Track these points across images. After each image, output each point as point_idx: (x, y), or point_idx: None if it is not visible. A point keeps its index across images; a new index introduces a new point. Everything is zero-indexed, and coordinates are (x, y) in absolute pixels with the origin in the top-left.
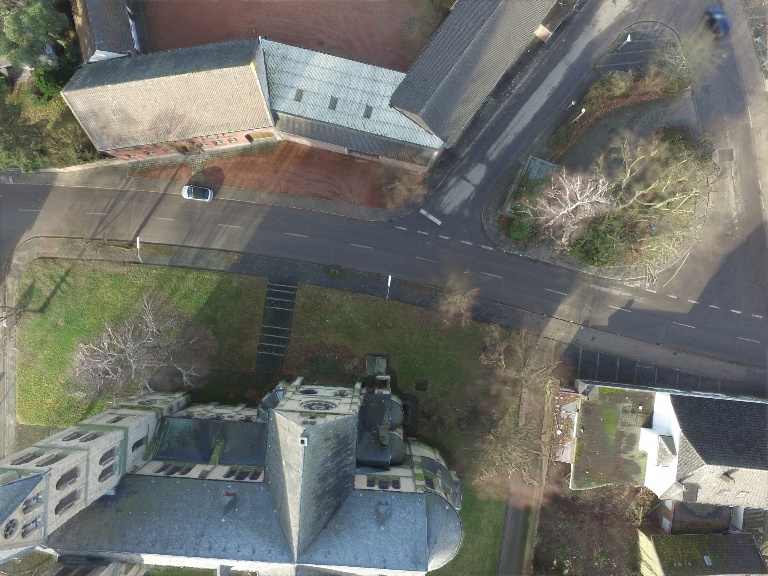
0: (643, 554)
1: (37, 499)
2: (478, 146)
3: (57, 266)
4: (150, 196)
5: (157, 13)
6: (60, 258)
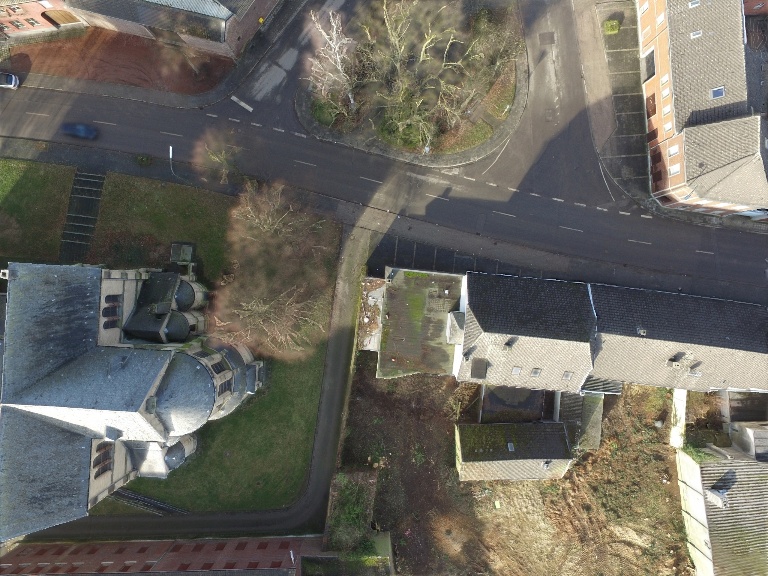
0: (456, 447)
1: None
2: (290, 30)
3: None
4: None
5: None
6: None
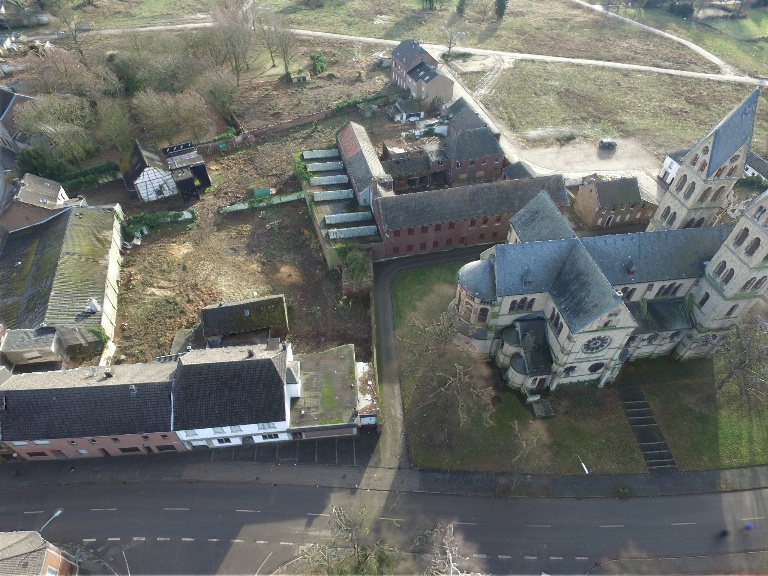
0: None
1: (767, 227)
2: None
3: None
4: None
5: None
6: None
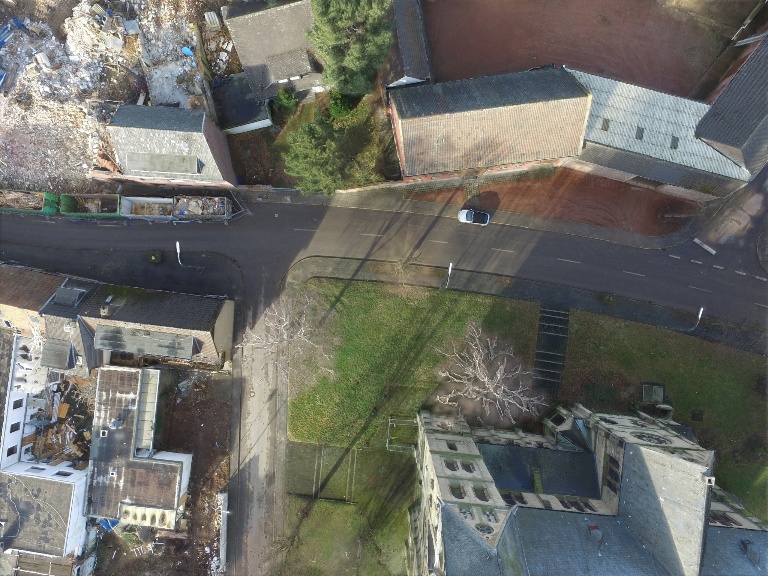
0: None
1: None
2: None
3: (332, 286)
4: (425, 219)
5: (440, 38)
6: (334, 278)
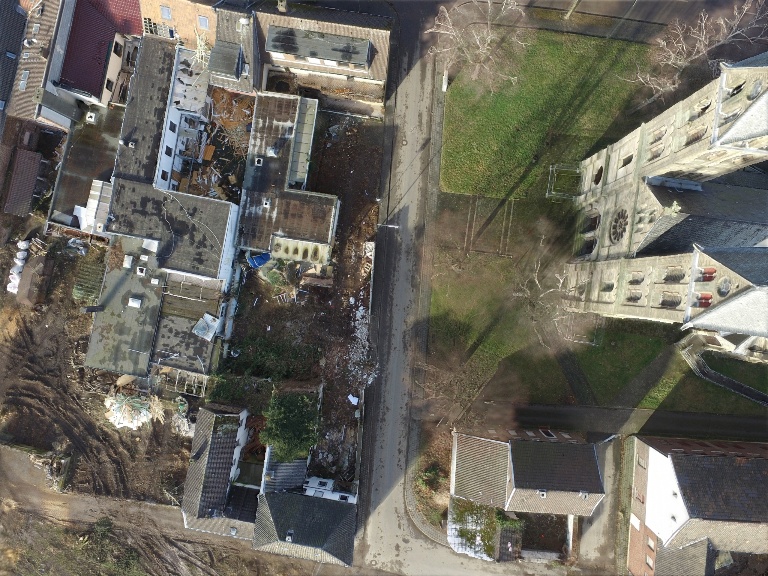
0: None
1: None
2: None
3: (493, 32)
4: None
5: None
6: (495, 24)
